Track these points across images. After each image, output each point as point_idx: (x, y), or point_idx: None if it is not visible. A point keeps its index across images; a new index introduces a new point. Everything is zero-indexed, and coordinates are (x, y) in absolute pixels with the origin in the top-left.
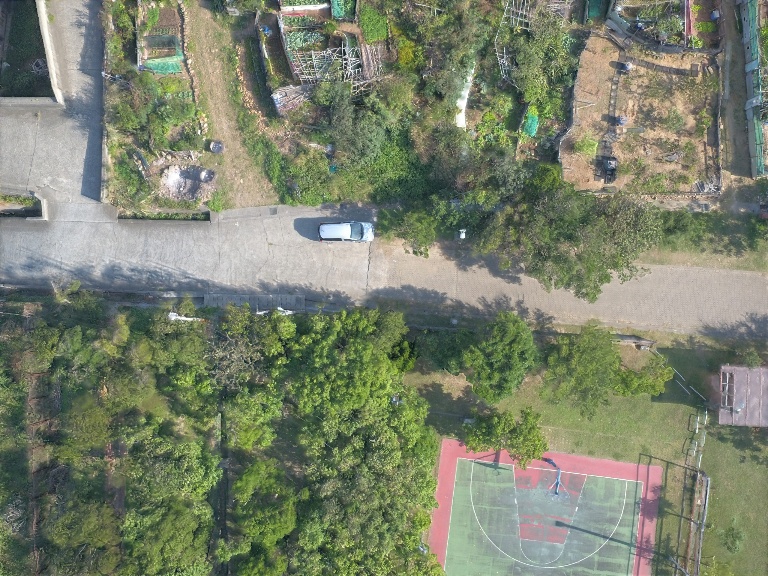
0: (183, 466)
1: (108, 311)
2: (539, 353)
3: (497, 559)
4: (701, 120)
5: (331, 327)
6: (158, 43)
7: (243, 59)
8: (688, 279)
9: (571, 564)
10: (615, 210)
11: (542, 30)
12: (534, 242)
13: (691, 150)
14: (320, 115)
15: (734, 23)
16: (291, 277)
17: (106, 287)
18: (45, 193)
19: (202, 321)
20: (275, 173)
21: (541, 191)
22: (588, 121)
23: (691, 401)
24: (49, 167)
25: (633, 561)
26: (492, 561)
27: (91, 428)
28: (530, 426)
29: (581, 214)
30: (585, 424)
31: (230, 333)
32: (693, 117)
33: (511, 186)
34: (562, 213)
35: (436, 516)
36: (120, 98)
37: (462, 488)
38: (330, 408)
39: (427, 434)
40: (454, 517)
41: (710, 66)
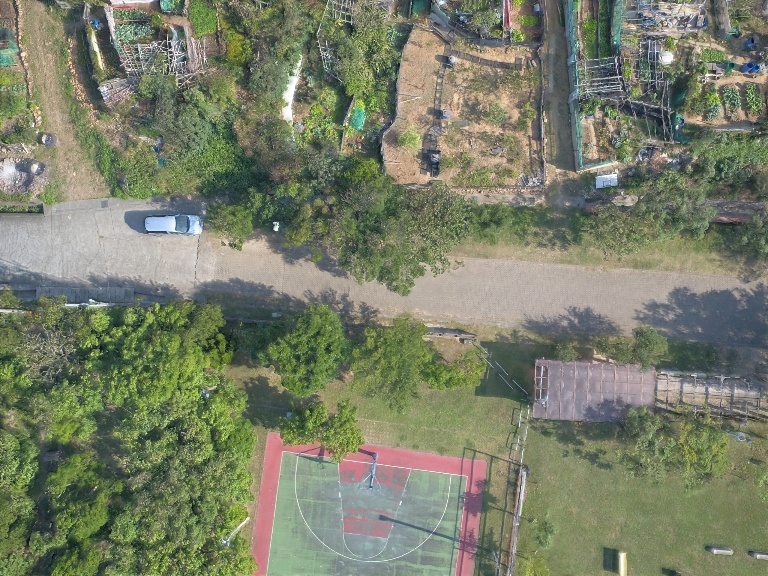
0: None
1: None
2: (347, 345)
3: (320, 553)
4: (525, 114)
5: (144, 319)
6: None
7: (75, 52)
8: (512, 273)
9: (394, 558)
10: (422, 202)
11: (364, 23)
12: (340, 234)
13: (512, 143)
14: (150, 108)
15: (557, 17)
16: (121, 270)
17: None
18: None
19: (27, 313)
20: (106, 166)
21: (349, 183)
22: (414, 114)
23: (515, 395)
24: None
25: (456, 555)
26: (316, 555)
27: None
28: (345, 419)
29: (391, 206)
30: (409, 418)
31: (45, 325)
32: (518, 111)
33: (323, 178)
34: (366, 205)
35: (260, 510)
36: None
37: (287, 482)
38: (138, 400)
39: (242, 427)
40: (278, 511)
41: (533, 60)
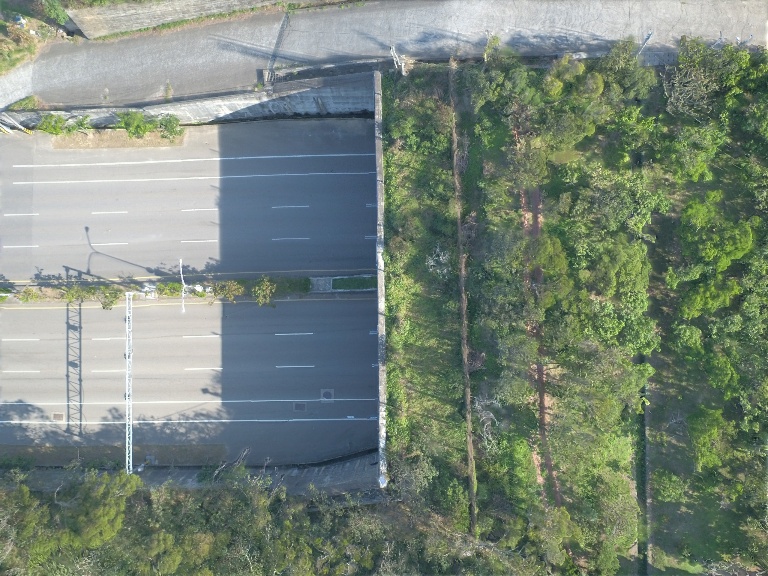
0: (636, 194)
1: None
2: None
3: None
4: None
5: None
6: None
7: None
8: None
9: None
10: None
11: None
12: None
13: None
14: None
15: None
16: (706, 33)
17: (506, 55)
18: None
19: None
20: None
21: None
22: None
23: None
24: None
25: None
26: None
27: (535, 164)
28: None
29: None
30: None
31: (681, 66)
32: None
33: None
34: None
35: None
36: None
37: None
38: None
39: None
40: None
41: None
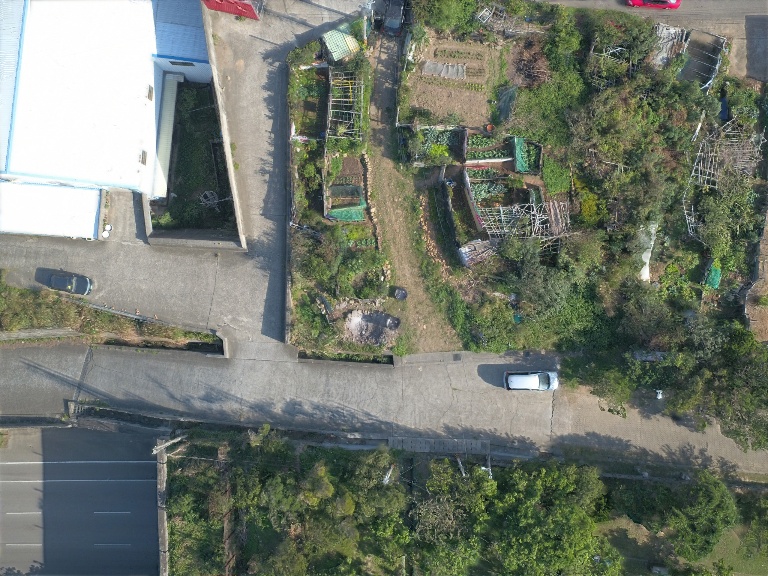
0: None
1: (294, 451)
2: (739, 515)
3: None
4: None
5: (531, 485)
6: (342, 192)
7: (427, 209)
8: None
9: None
10: None
11: (729, 188)
12: (736, 408)
13: None
14: (504, 265)
15: None
16: (476, 422)
17: (287, 425)
18: (225, 331)
19: (393, 468)
20: (459, 321)
21: (741, 357)
22: None
23: None
24: (229, 306)
25: None
26: None
27: (292, 575)
28: None
29: None
30: None
31: (431, 489)
32: None
33: (709, 349)
34: (766, 382)
35: None
36: (307, 247)
37: None
38: (534, 567)
39: None
40: None
41: None
